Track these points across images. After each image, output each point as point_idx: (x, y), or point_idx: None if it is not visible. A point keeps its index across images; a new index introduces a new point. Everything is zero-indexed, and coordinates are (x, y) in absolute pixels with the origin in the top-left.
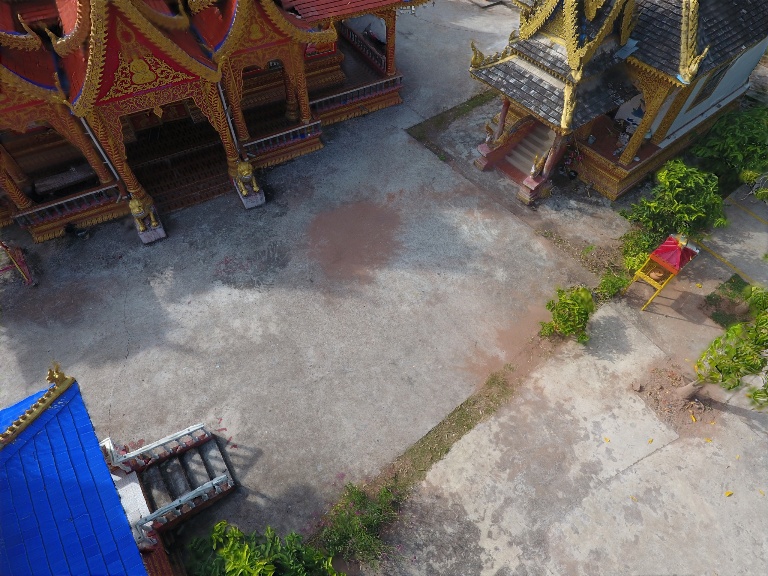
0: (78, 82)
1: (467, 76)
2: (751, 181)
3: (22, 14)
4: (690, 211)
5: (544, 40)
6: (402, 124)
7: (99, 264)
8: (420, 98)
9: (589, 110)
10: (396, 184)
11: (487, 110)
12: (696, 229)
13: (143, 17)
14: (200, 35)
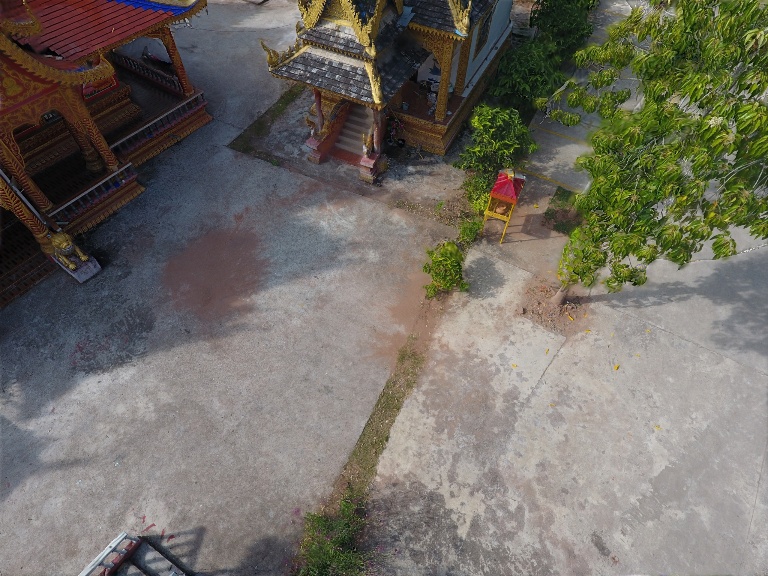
0: None
1: (269, 76)
2: (543, 107)
3: None
4: (507, 146)
5: (329, 25)
6: (221, 141)
7: None
8: (230, 110)
9: (394, 81)
10: (239, 203)
11: (301, 104)
12: (517, 160)
13: None
14: None
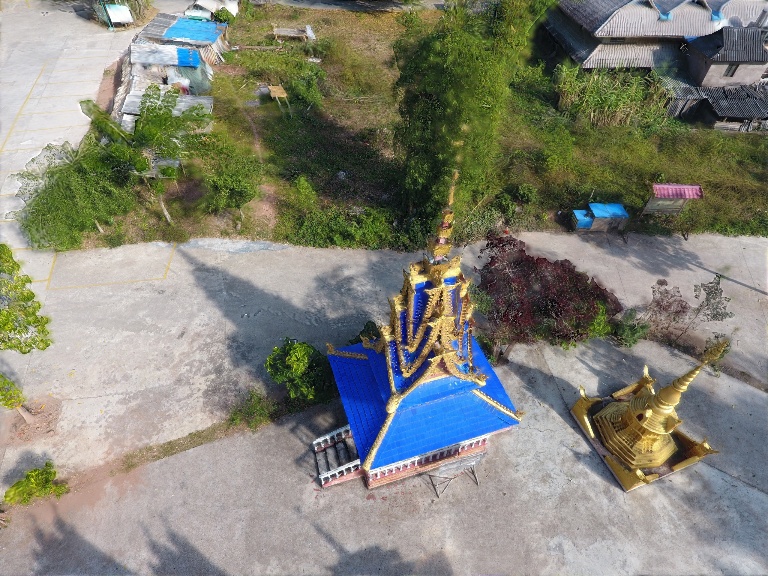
0: None
1: None
2: None
3: None
4: None
5: None
6: None
7: None
8: None
9: None
10: None
11: None
12: None
13: None
14: None
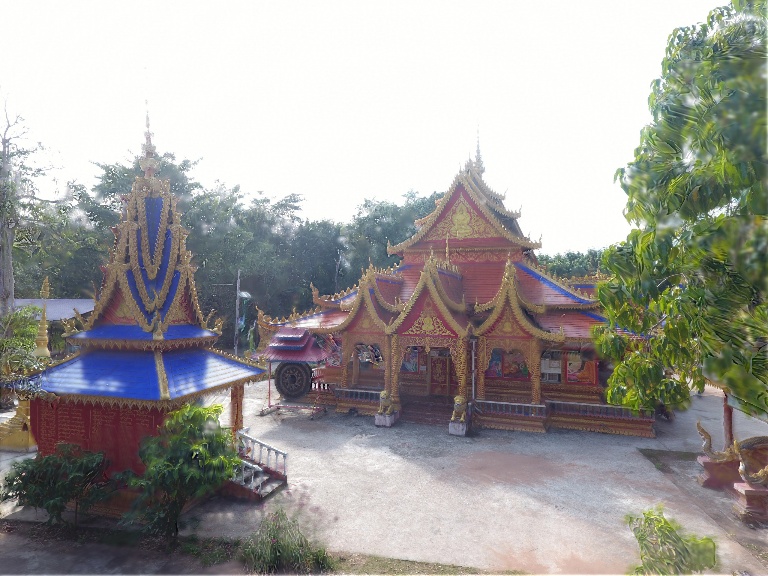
0: None
1: None
2: None
3: None
4: None
5: None
6: (638, 445)
7: (346, 424)
8: (679, 441)
9: None
10: (586, 462)
11: None
12: None
13: (437, 294)
14: None
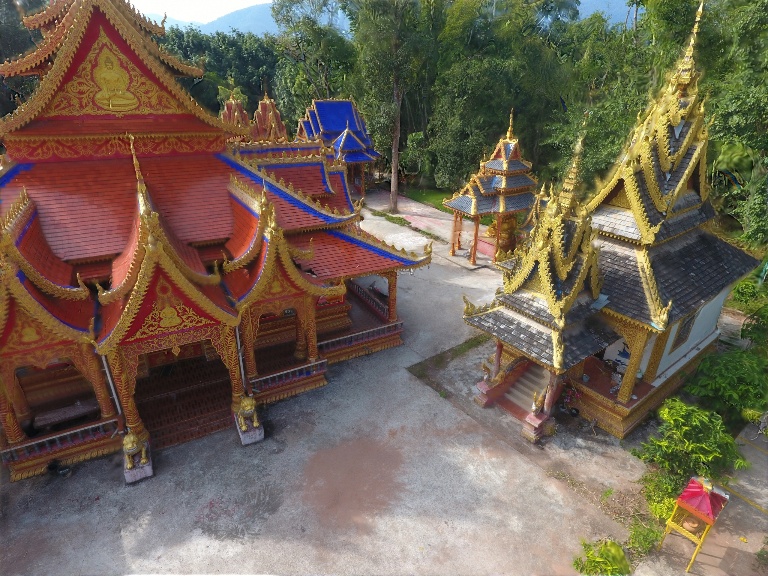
0: (110, 325)
1: (461, 322)
2: (755, 420)
3: (81, 273)
4: (704, 451)
5: (526, 295)
6: (403, 363)
7: (71, 507)
8: (419, 340)
9: (578, 352)
10: (398, 420)
11: (482, 351)
12: (717, 471)
13: (182, 276)
14: (228, 289)
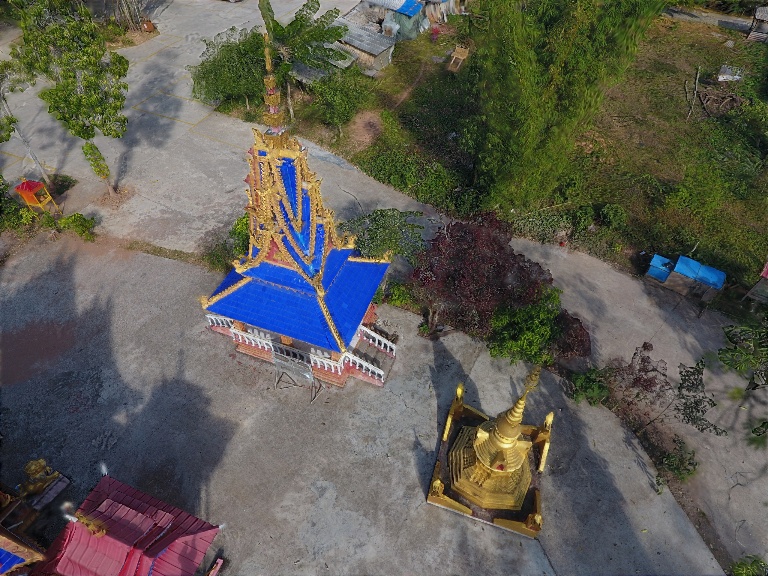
0: None
1: None
2: None
3: None
4: None
5: None
6: None
7: None
8: None
9: None
10: None
11: None
12: (5, 184)
13: None
14: None
